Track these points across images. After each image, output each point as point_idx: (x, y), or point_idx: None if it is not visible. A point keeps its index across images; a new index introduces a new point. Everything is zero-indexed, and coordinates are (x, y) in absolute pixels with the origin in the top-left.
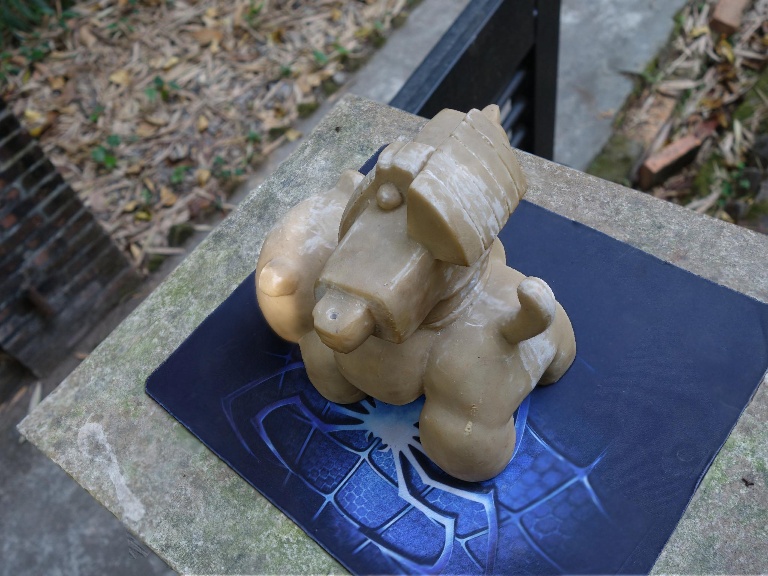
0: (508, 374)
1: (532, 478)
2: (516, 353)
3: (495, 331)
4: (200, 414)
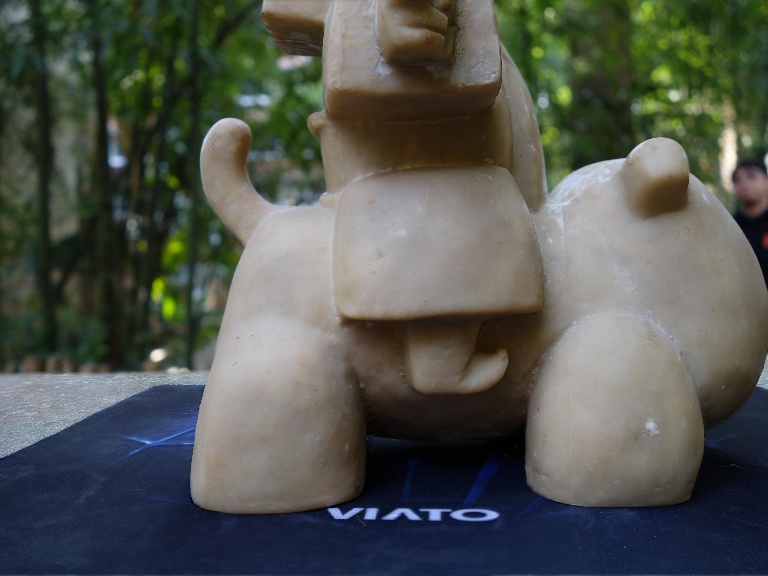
0: None
1: None
2: None
3: None
4: None
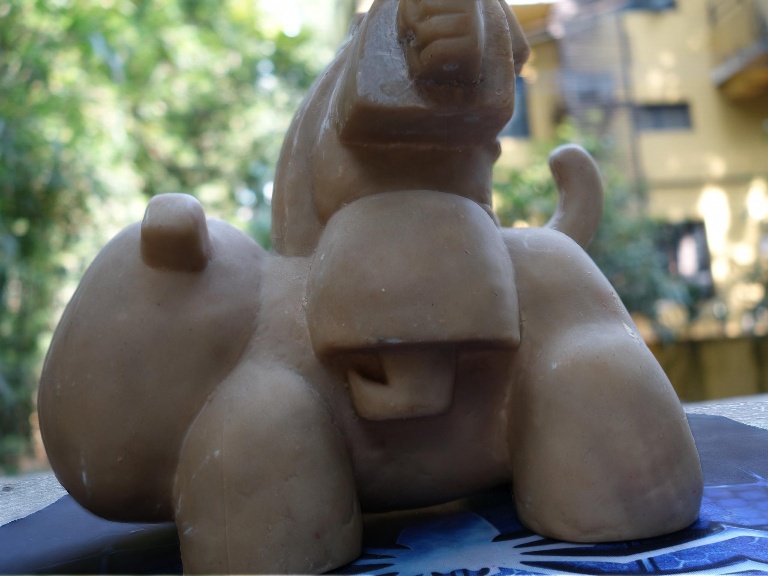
0: None
1: (736, 502)
2: None
3: None
4: None
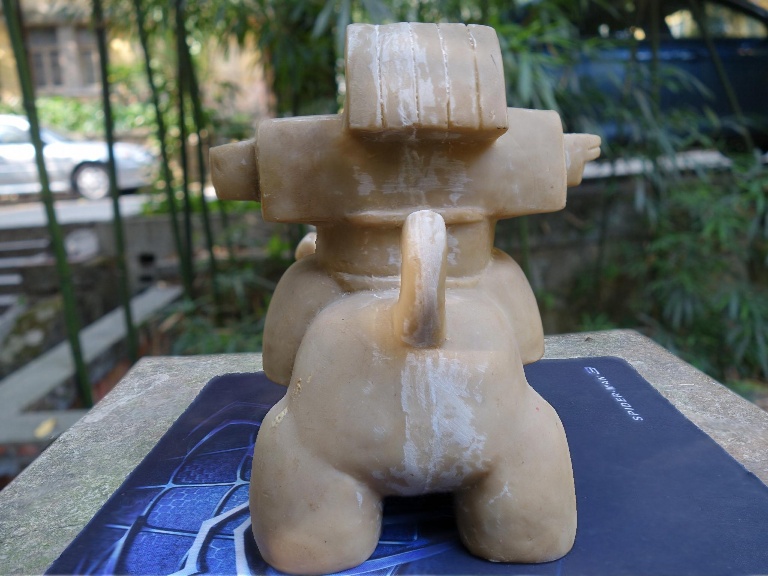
0: (367, 377)
1: None
2: (398, 362)
3: (387, 307)
4: (212, 400)
